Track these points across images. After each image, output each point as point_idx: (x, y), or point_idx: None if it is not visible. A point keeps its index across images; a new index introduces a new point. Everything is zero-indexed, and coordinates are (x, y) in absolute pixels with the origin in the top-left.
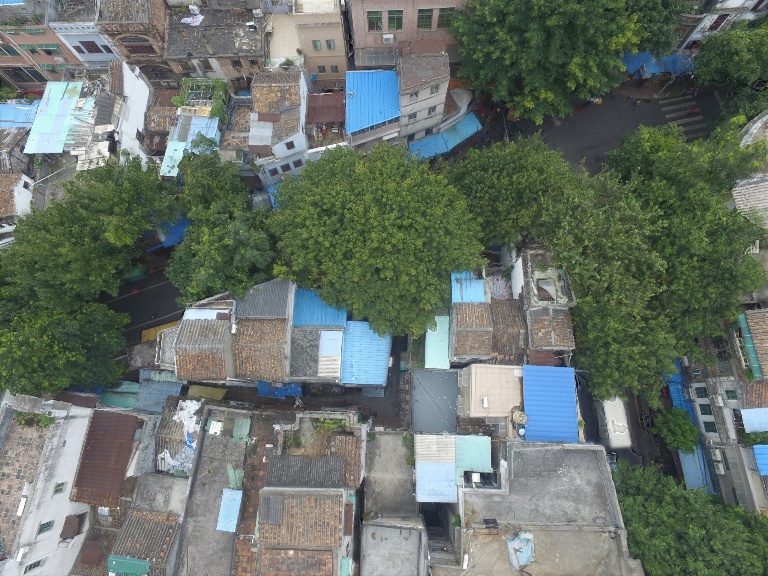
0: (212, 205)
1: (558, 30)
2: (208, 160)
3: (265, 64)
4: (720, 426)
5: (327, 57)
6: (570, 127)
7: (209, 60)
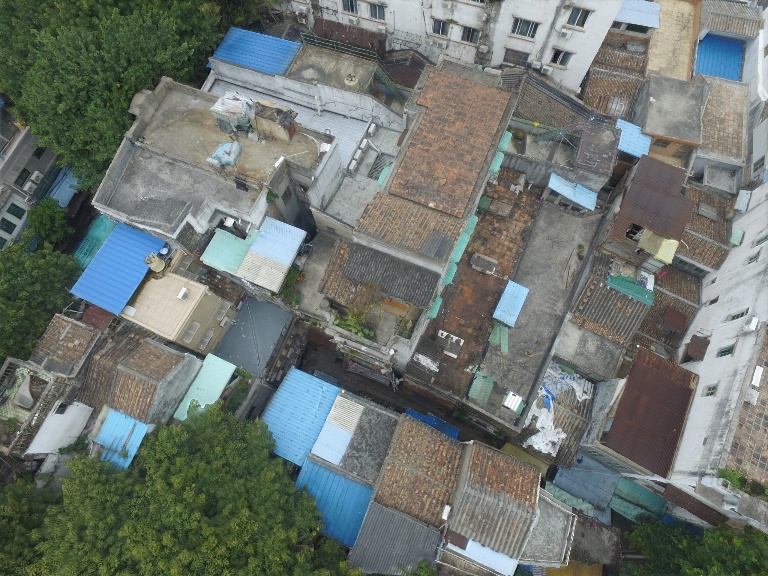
0: None
1: None
2: None
3: None
4: (1, 204)
5: None
6: None
7: None
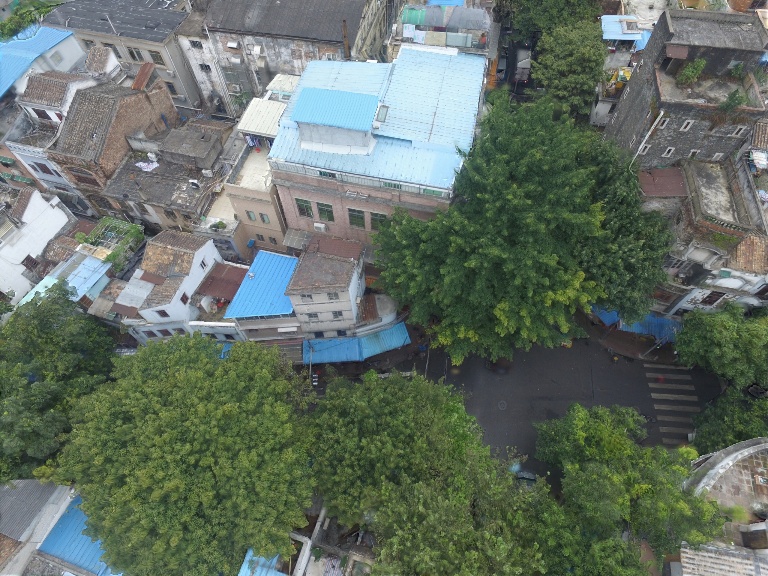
0: (16, 365)
1: (479, 269)
2: (51, 310)
3: (197, 221)
4: None
5: (263, 228)
6: (526, 366)
7: (144, 205)
